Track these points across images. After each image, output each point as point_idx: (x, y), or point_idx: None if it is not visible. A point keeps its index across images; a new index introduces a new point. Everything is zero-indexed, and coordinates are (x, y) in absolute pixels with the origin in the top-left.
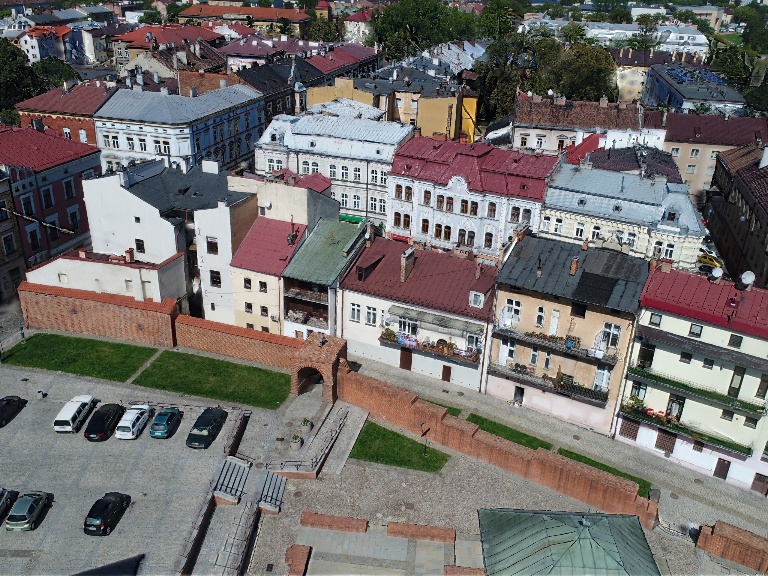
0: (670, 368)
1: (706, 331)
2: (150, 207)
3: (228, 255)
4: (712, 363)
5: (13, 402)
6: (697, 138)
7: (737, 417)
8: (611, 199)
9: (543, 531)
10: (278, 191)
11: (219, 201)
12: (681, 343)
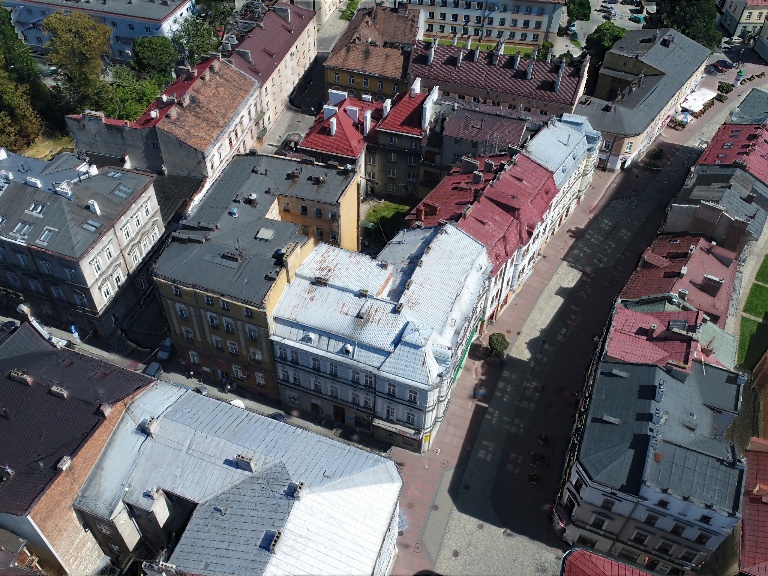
0: None
1: None
2: None
3: None
4: None
5: None
6: (276, 59)
7: None
8: None
9: None
10: None
11: None
12: None
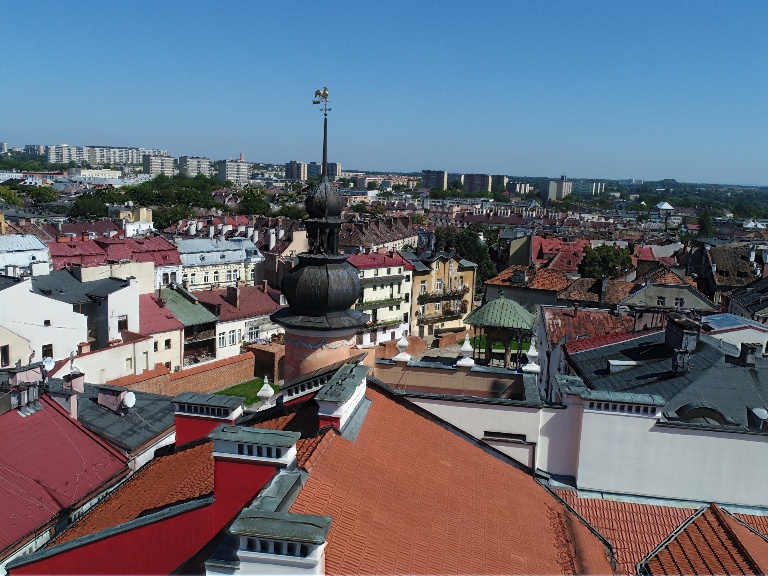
0: (372, 296)
1: (380, 271)
2: (64, 305)
3: (137, 327)
4: (383, 286)
5: None
6: None
7: (394, 308)
8: (217, 252)
9: (496, 305)
10: (131, 270)
11: (131, 279)
12: (376, 280)
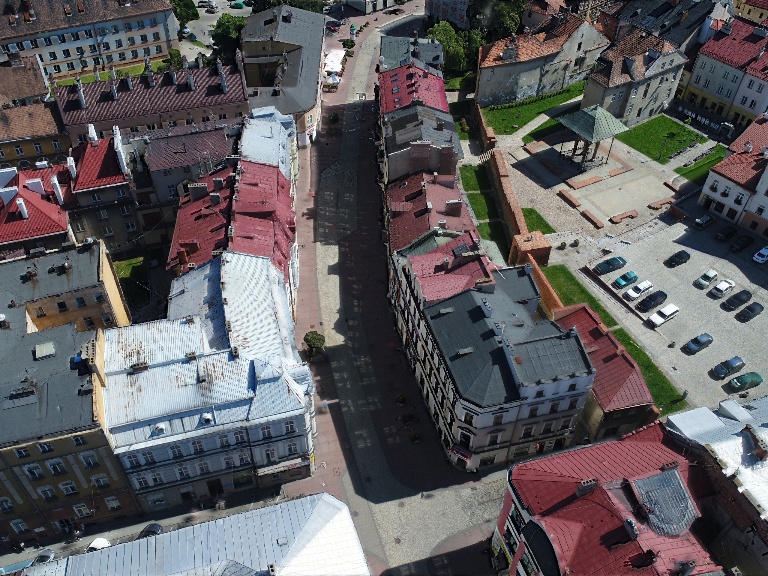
0: None
1: None
2: None
3: None
4: None
5: (693, 339)
6: None
7: None
8: None
9: None
10: None
11: None
12: None
